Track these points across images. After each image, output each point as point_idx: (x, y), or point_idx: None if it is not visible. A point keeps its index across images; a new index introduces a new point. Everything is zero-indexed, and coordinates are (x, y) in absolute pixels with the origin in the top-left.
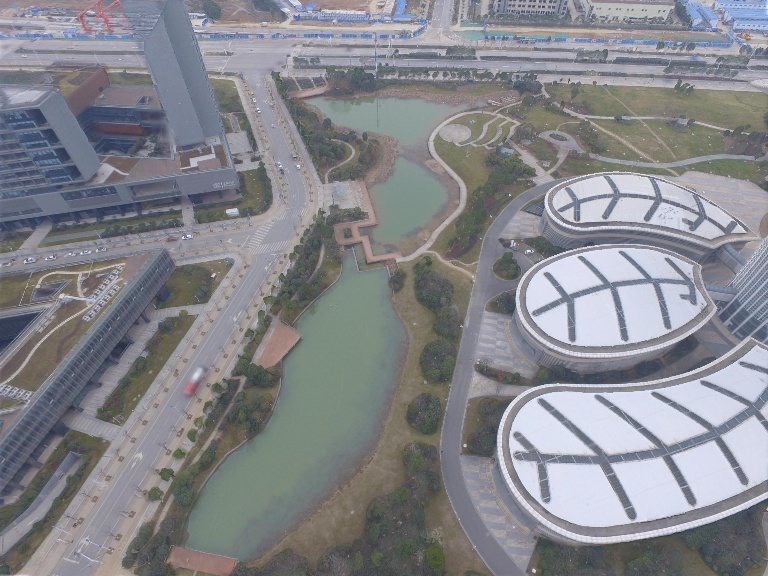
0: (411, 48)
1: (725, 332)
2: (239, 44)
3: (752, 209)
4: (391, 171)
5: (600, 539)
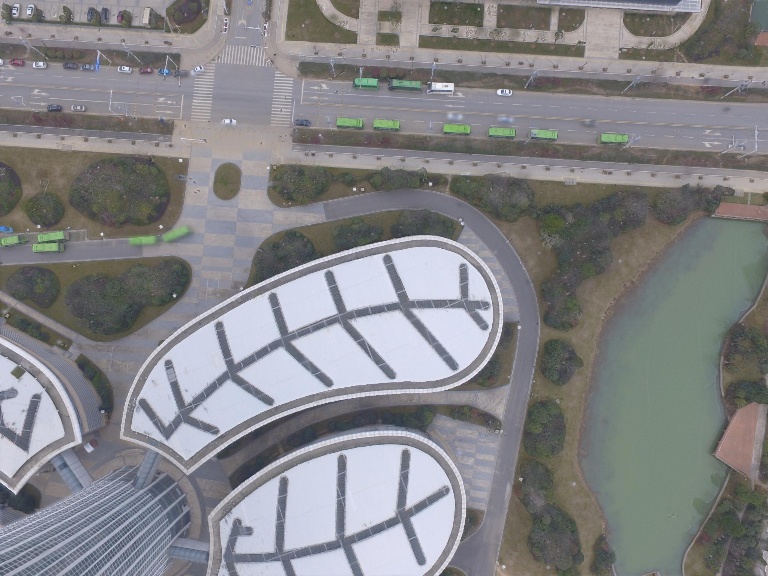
0: None
1: (192, 496)
2: None
3: None
4: None
5: (419, 238)
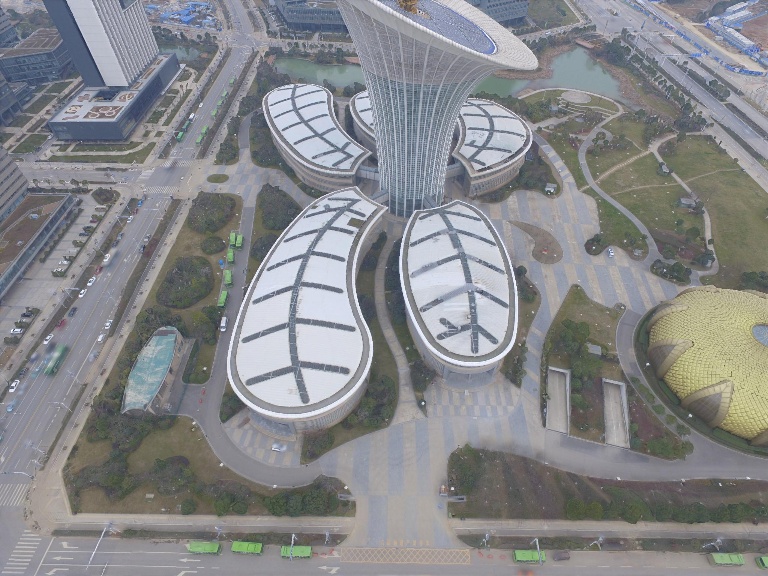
0: (709, 72)
1: None
2: (636, 16)
3: (550, 224)
4: (510, 78)
5: None
